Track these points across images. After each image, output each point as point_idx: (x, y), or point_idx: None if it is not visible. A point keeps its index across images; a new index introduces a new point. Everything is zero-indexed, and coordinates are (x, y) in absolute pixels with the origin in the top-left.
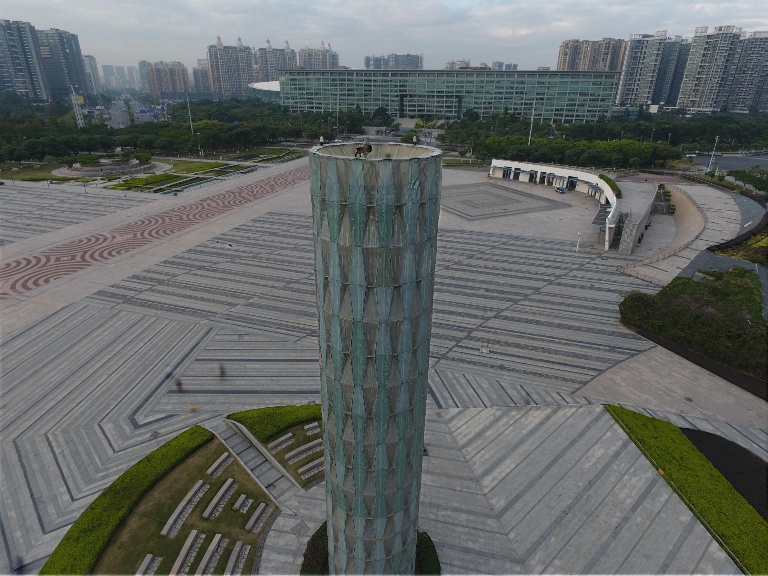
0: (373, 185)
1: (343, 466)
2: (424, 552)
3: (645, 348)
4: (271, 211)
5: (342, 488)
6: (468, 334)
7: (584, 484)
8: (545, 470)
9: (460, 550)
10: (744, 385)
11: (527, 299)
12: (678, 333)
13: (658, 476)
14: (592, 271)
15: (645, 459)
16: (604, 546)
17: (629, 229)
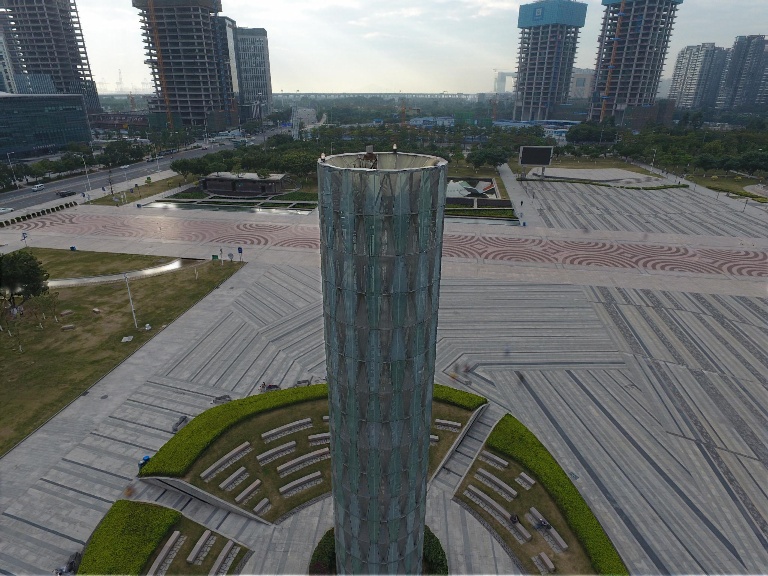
0: None
1: None
2: None
3: None
4: None
5: None
6: None
7: None
8: None
9: None
10: None
11: None
12: None
13: None
14: None
15: None
16: None
17: None
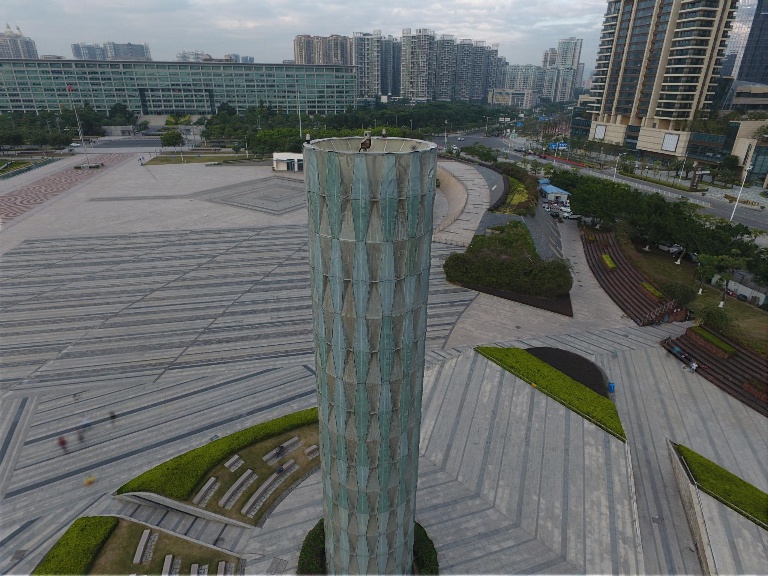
0: (402, 178)
1: (367, 469)
2: None
3: (473, 297)
4: (28, 239)
5: (365, 492)
6: None
7: (490, 415)
8: (458, 416)
9: (430, 510)
10: (544, 306)
11: None
12: (491, 279)
13: (533, 389)
14: None
15: (520, 380)
16: (525, 455)
17: None
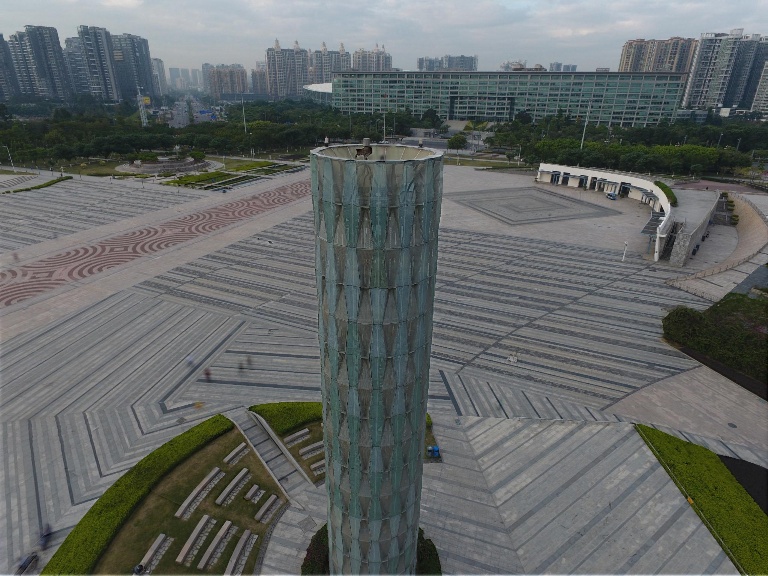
0: (367, 187)
1: (339, 465)
2: (426, 559)
3: (688, 367)
4: None
5: (339, 487)
6: (497, 341)
7: (603, 506)
8: (563, 487)
9: (465, 561)
10: None
11: (563, 309)
12: (726, 353)
13: (686, 505)
14: (637, 283)
15: (674, 485)
16: (619, 573)
17: (682, 240)
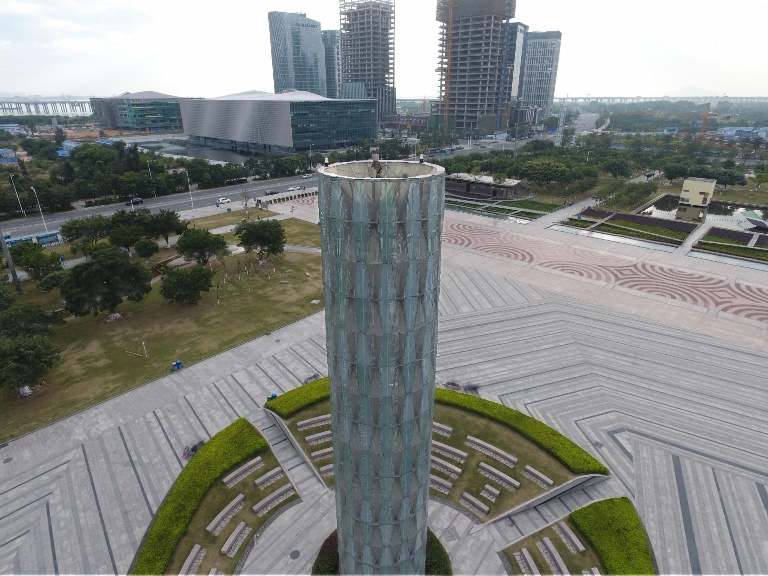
0: None
1: None
2: None
3: None
4: None
5: None
6: None
7: None
8: None
9: None
10: None
11: None
12: None
13: None
14: None
15: None
16: None
17: None
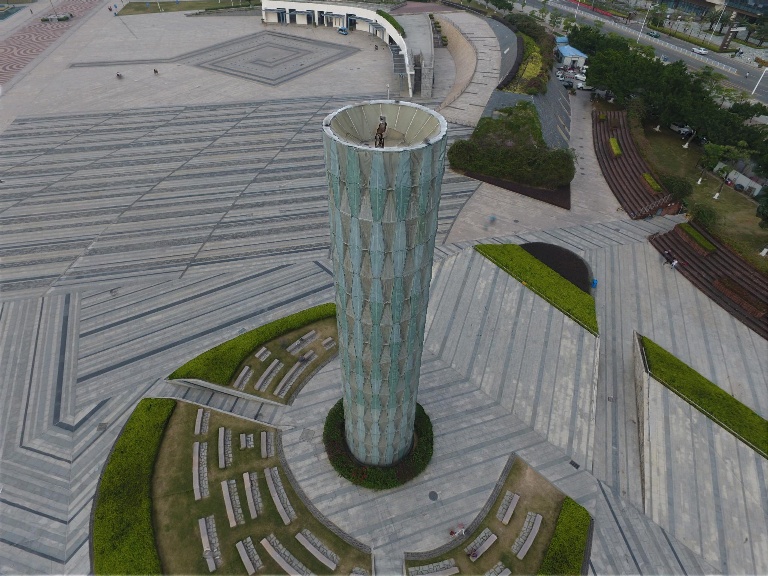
0: (415, 168)
1: (380, 381)
2: None
3: (475, 187)
4: (18, 117)
5: (378, 396)
6: None
7: (483, 311)
8: (455, 311)
9: (427, 391)
10: (544, 198)
11: None
12: (495, 169)
13: (523, 287)
14: None
15: (512, 278)
16: (510, 346)
17: (427, 73)
